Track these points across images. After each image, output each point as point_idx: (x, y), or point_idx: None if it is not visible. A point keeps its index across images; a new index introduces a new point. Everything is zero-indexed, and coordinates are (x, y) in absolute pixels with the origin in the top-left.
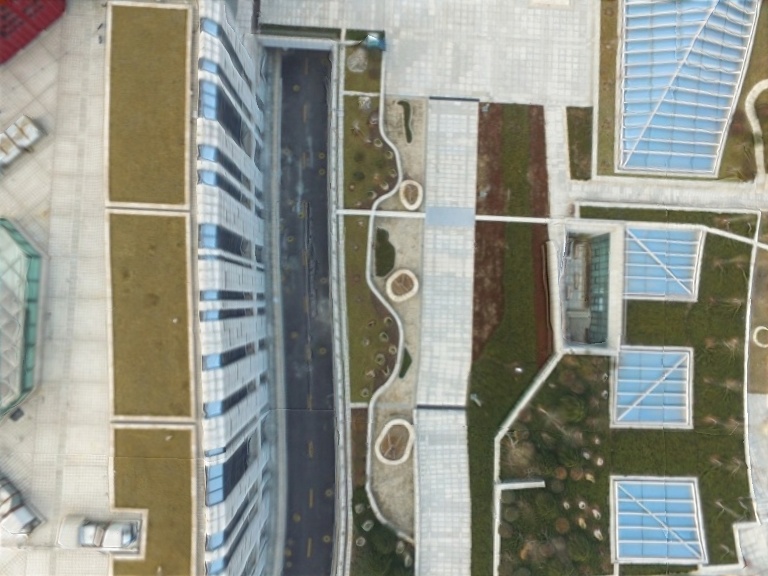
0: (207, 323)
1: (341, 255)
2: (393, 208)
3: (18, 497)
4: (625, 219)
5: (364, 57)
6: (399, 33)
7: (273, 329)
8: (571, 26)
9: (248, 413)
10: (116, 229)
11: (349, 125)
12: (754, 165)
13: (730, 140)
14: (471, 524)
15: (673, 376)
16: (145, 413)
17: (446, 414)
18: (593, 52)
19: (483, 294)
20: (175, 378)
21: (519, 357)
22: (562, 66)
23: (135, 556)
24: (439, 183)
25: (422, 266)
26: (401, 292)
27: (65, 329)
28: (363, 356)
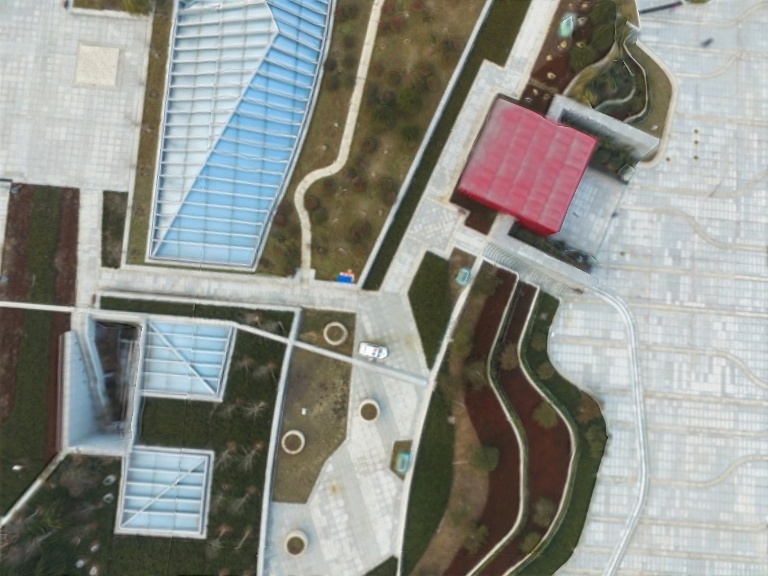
0: None
1: None
2: None
3: None
4: (148, 312)
5: None
6: None
7: None
8: (116, 107)
9: None
10: None
11: None
12: (298, 259)
13: (273, 232)
14: None
15: (187, 481)
16: None
17: None
18: (134, 135)
19: None
20: None
21: (26, 453)
22: (103, 148)
23: None
24: None
25: None
26: None
27: None
28: None
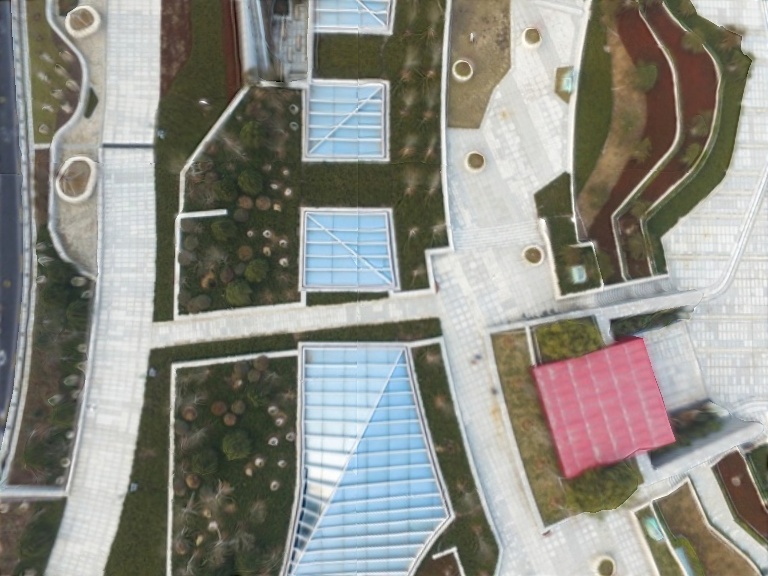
0: None
1: None
2: None
3: None
4: None
5: None
6: None
7: None
8: None
9: None
10: None
11: None
12: None
13: None
14: (156, 259)
15: (367, 108)
16: None
17: (133, 152)
18: None
19: (171, 31)
20: None
21: (208, 93)
22: None
23: None
24: None
25: (107, 5)
26: (79, 26)
27: None
28: (45, 95)
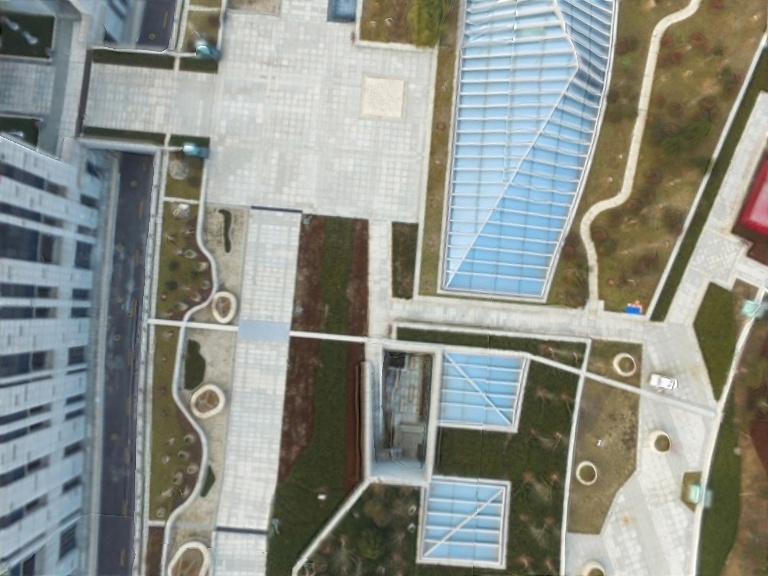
0: None
1: (150, 366)
2: (205, 320)
3: None
4: (444, 343)
5: (184, 165)
6: (224, 140)
7: (93, 430)
8: (402, 139)
9: (24, 535)
10: None
11: (166, 232)
12: (586, 290)
13: (561, 263)
14: None
15: (486, 511)
16: None
17: (246, 538)
18: (422, 167)
19: (293, 413)
20: None
21: (326, 482)
22: (390, 179)
23: None
24: (255, 295)
25: (232, 381)
26: (204, 409)
27: None
28: (164, 473)
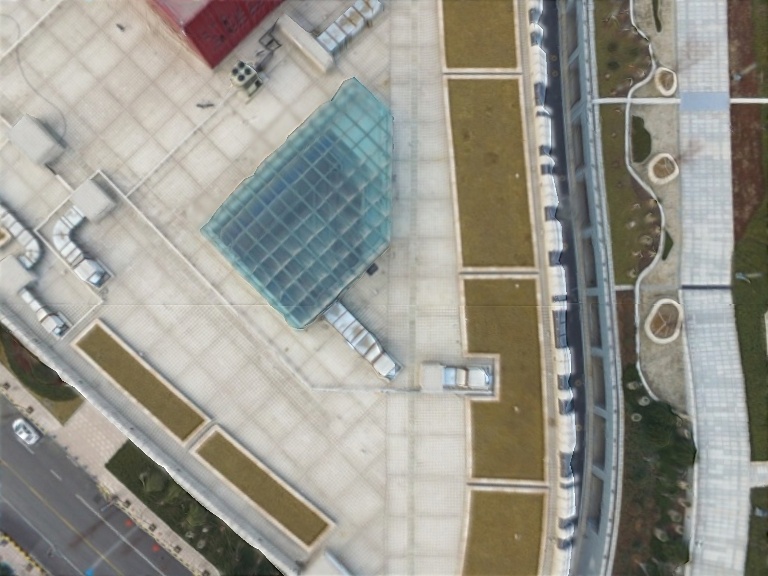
0: (549, 176)
1: (598, 143)
2: (648, 95)
3: (379, 344)
4: None
5: None
6: None
7: None
8: None
9: None
10: (454, 93)
11: (600, 18)
12: None
13: None
14: (746, 399)
15: None
16: (491, 264)
17: (711, 294)
18: None
19: (742, 175)
20: (517, 230)
21: None
22: None
23: (490, 398)
24: (691, 69)
25: (679, 151)
26: (664, 174)
27: (409, 189)
28: (626, 239)
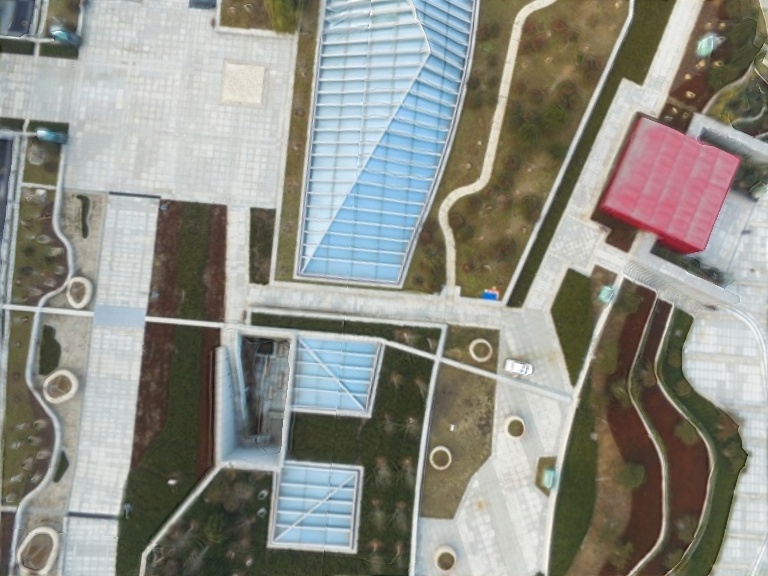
0: None
1: (5, 351)
2: (61, 305)
3: None
4: (298, 328)
5: (41, 150)
6: (84, 126)
7: None
8: (262, 125)
9: None
10: None
11: (23, 218)
12: (443, 276)
13: (418, 249)
14: None
15: (338, 496)
16: None
17: (98, 523)
18: (281, 153)
19: (148, 399)
20: None
21: (178, 467)
22: (250, 165)
23: None
24: (112, 281)
25: (87, 366)
26: (55, 394)
27: None
28: (16, 458)
